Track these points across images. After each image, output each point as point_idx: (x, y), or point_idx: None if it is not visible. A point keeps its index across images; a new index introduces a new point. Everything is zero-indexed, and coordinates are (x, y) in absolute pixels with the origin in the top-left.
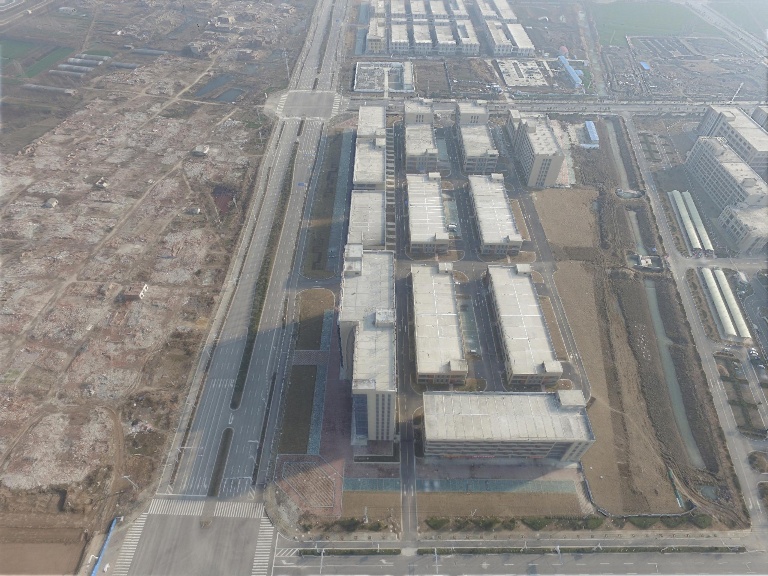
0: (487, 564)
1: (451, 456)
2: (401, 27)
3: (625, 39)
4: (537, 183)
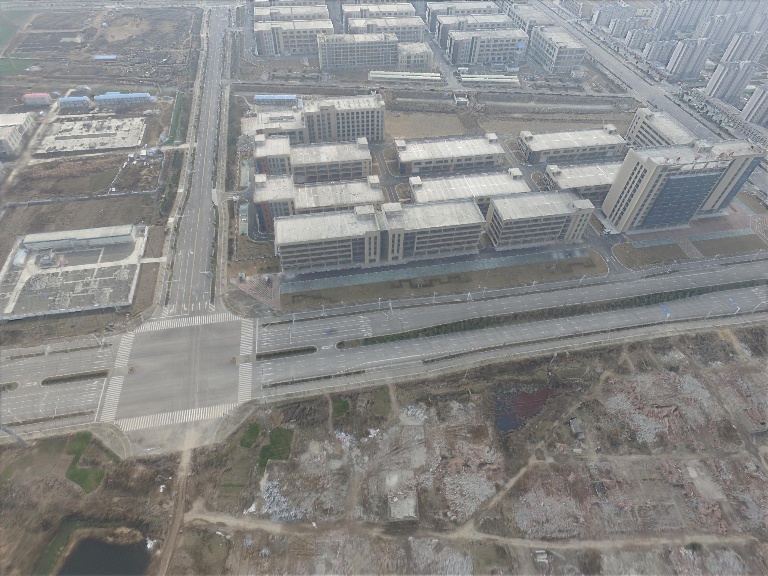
0: None
1: None
2: None
3: None
4: None
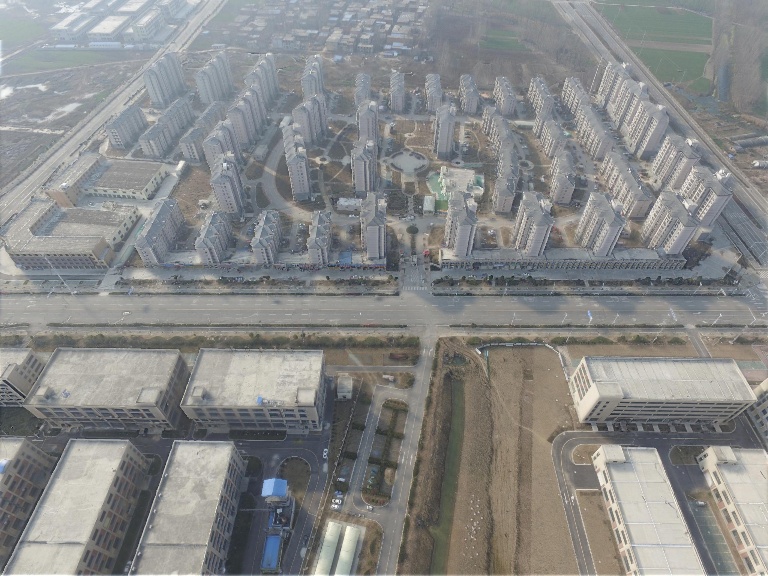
0: (633, 320)
1: None
2: None
3: None
4: None
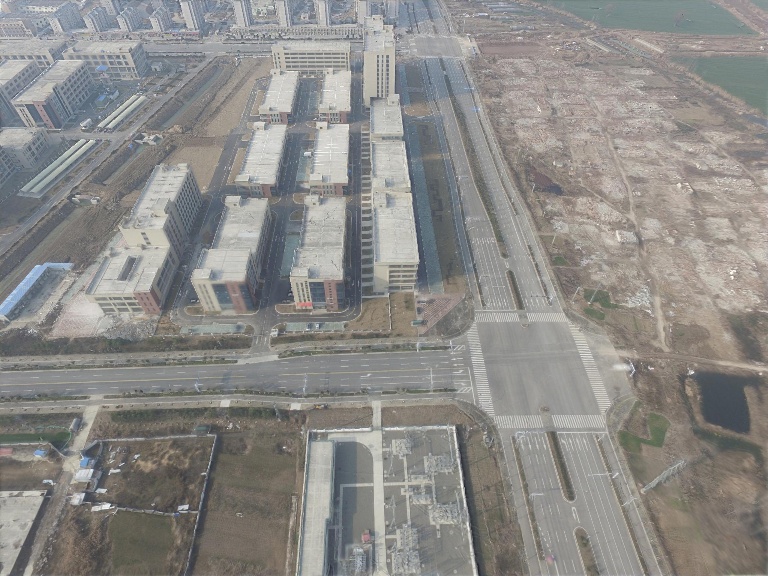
0: None
1: None
2: None
3: None
4: None
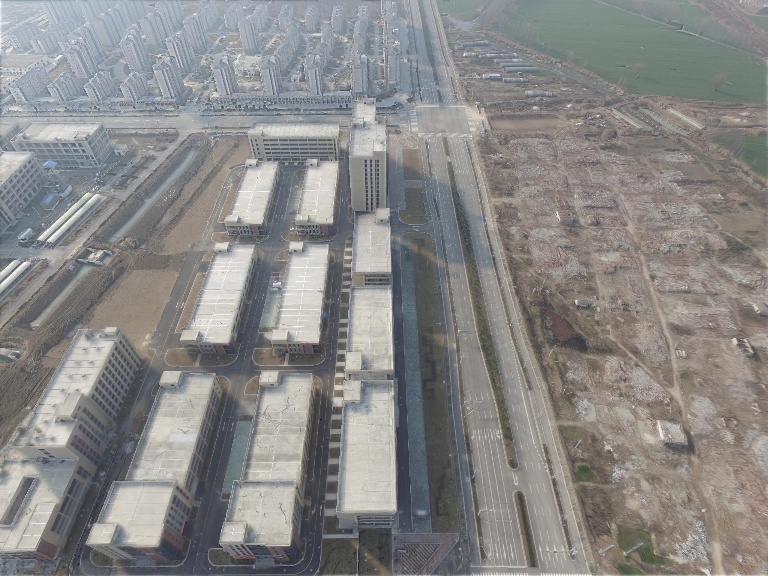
0: None
1: None
2: None
3: None
4: None
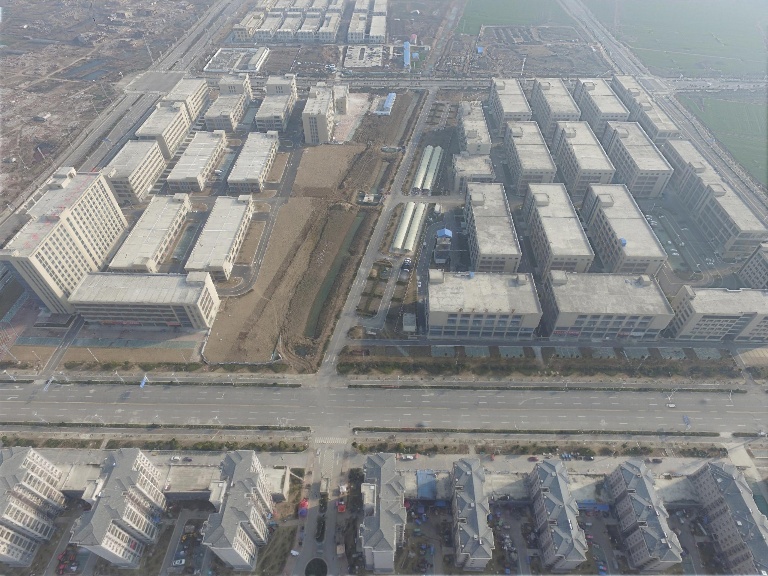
0: (94, 390)
1: (106, 322)
2: (275, 19)
3: (479, 28)
4: (313, 140)
